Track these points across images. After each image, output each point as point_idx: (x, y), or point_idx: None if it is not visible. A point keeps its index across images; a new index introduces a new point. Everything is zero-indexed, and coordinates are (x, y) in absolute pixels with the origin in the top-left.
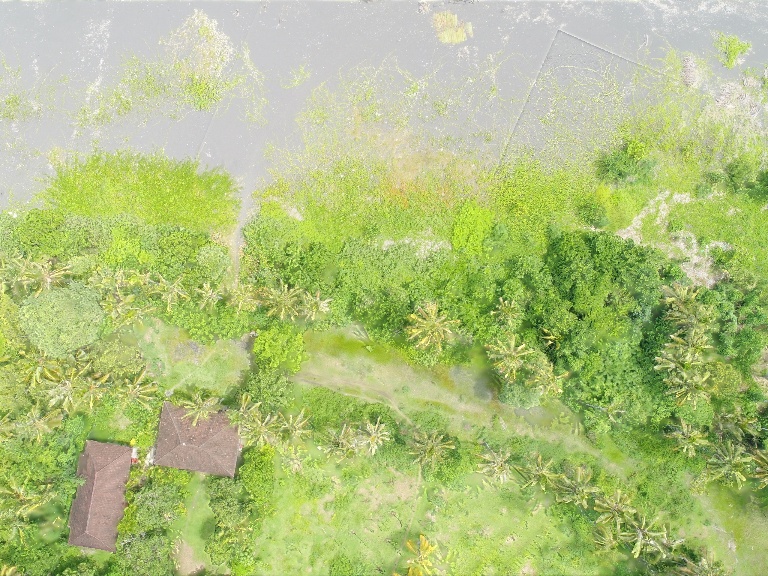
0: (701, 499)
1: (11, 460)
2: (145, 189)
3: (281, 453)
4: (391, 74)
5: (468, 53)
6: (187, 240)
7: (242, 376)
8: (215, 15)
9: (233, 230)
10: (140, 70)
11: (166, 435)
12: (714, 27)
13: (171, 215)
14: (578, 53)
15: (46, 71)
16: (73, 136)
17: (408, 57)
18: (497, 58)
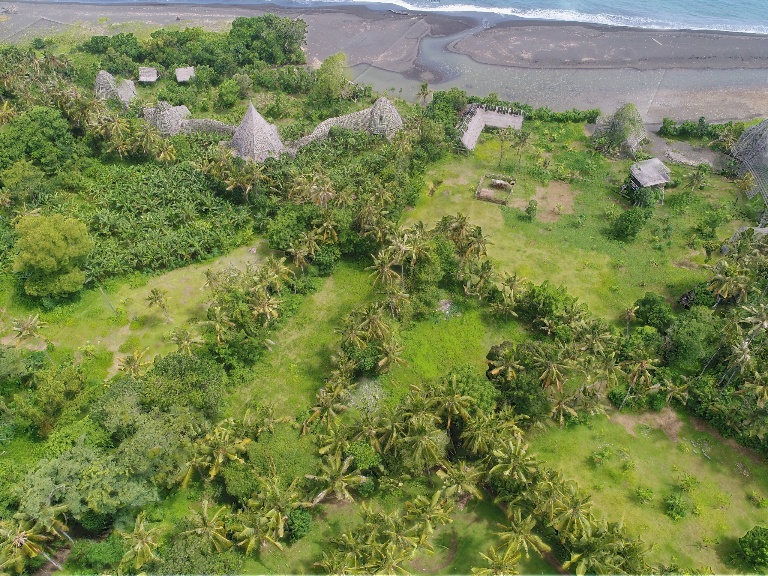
0: None
1: None
2: None
3: None
4: None
5: None
6: None
7: None
8: None
9: None
10: None
11: None
12: None
13: None
14: None
15: None
16: None
17: None
18: None
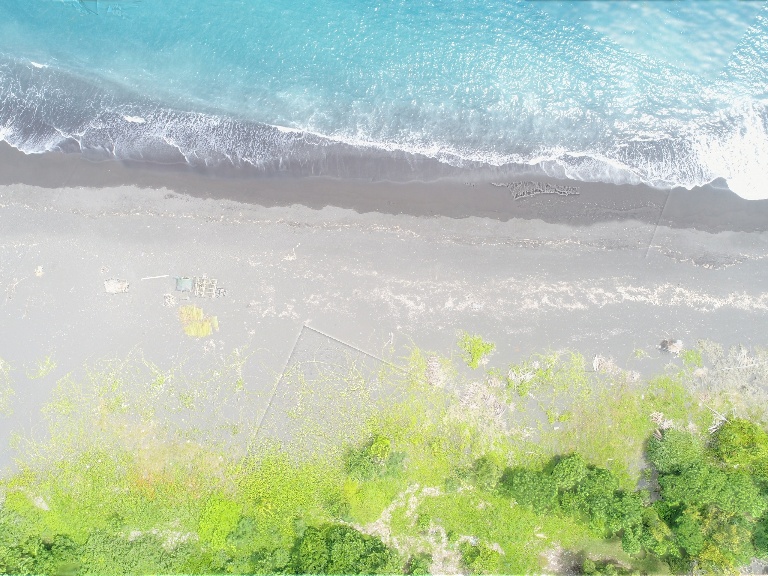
0: None
1: None
2: None
3: None
4: (137, 366)
5: (214, 347)
6: None
7: None
8: None
9: None
10: None
11: None
12: (459, 326)
13: None
14: (324, 348)
15: None
16: None
17: (154, 349)
18: (243, 352)
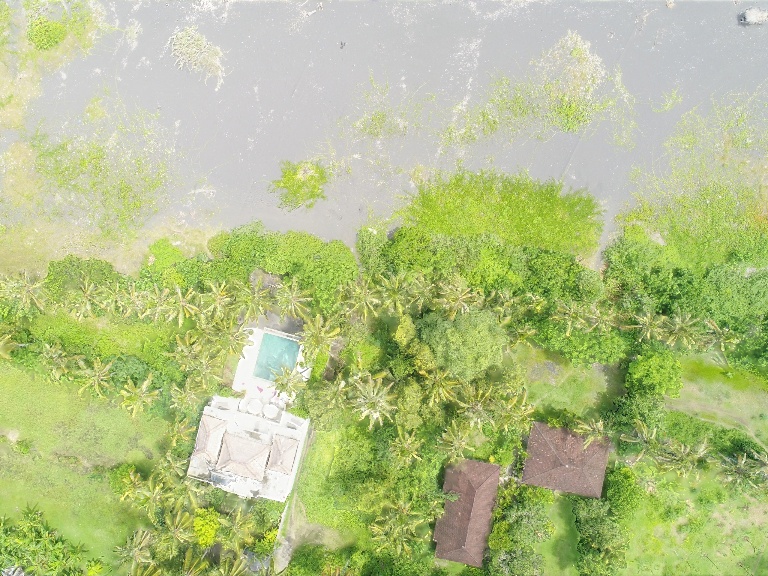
0: None
1: (396, 476)
2: (509, 209)
3: (636, 475)
4: (765, 100)
5: None
6: (561, 263)
7: (599, 398)
8: (589, 36)
9: (594, 253)
10: (509, 90)
11: (539, 455)
12: None
13: (533, 236)
14: None
15: (414, 89)
16: (437, 154)
17: None
18: None
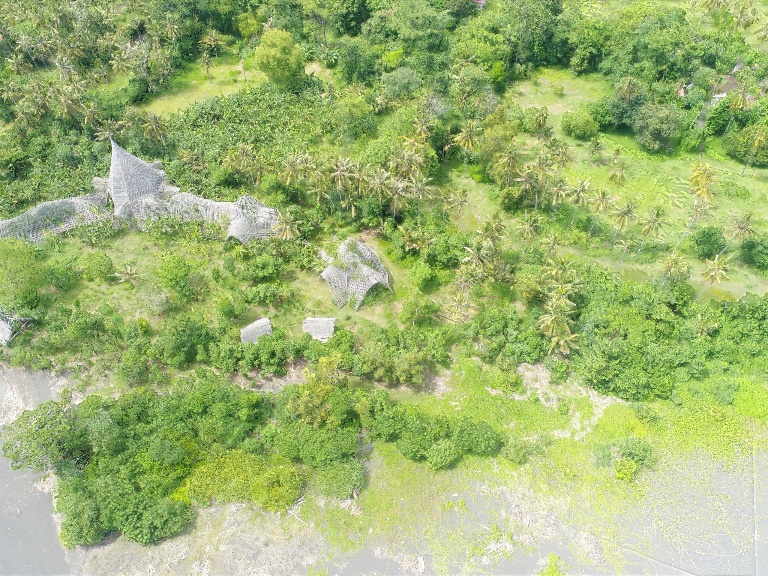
0: (503, 238)
1: None
2: None
3: None
4: None
5: None
6: None
7: None
8: None
9: None
10: None
11: None
12: None
13: None
14: (722, 571)
15: None
16: None
17: None
18: None
